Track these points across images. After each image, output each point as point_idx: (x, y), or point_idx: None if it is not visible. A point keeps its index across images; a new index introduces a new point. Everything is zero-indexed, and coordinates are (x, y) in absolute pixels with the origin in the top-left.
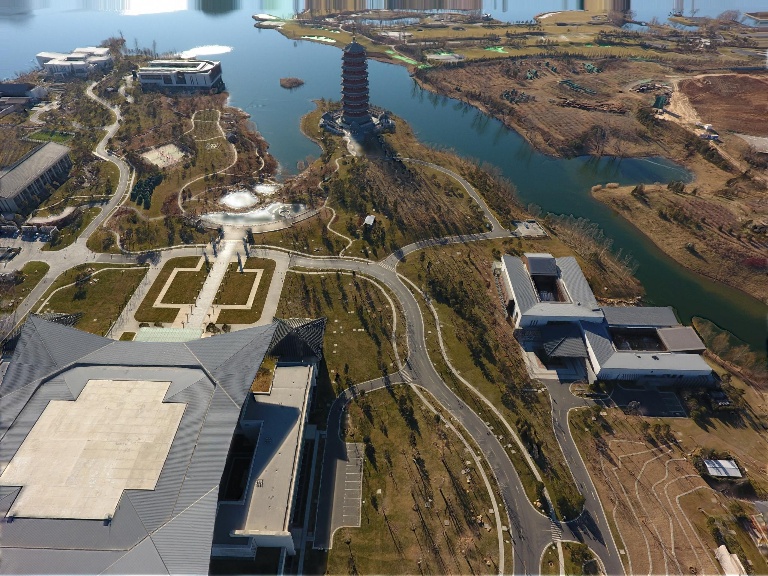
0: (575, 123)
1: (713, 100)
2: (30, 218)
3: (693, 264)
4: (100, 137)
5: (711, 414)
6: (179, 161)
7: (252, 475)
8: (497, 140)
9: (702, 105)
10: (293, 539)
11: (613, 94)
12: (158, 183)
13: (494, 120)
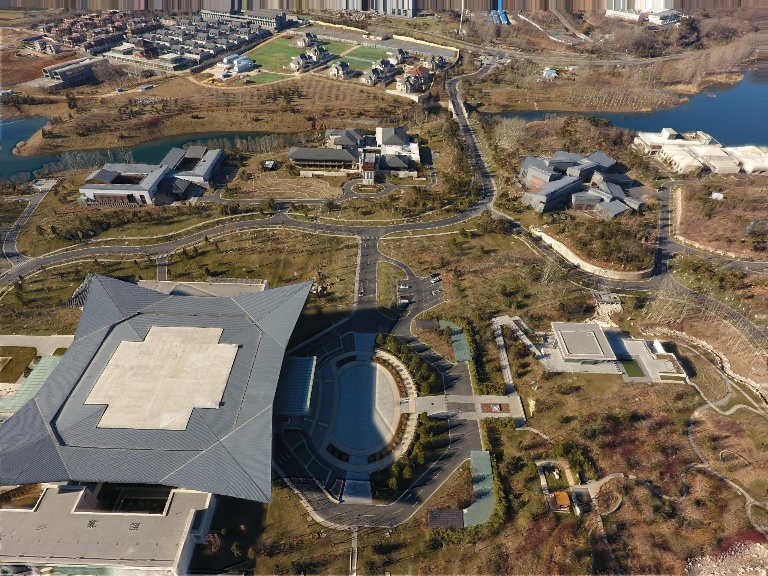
0: None
1: None
2: None
3: (135, 142)
4: None
5: (241, 162)
6: None
7: None
8: None
9: None
10: None
11: None
12: None
13: None
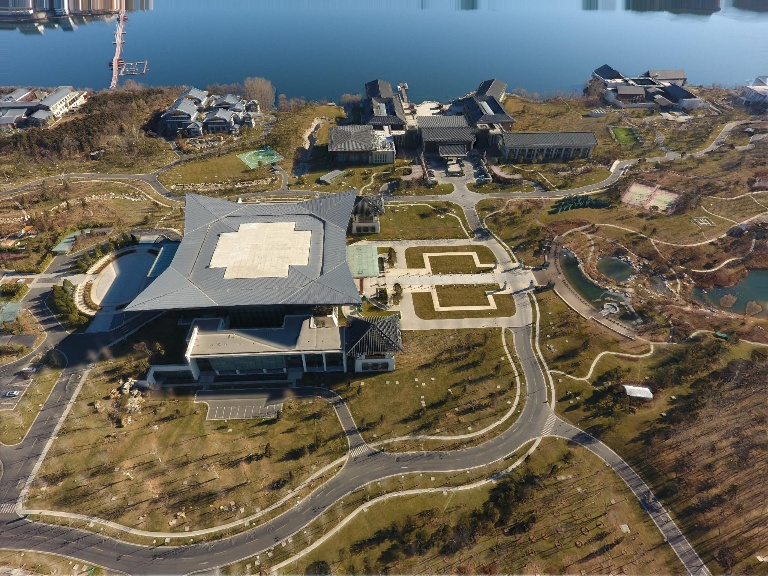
0: None
1: None
2: (500, 166)
3: None
4: (649, 155)
5: None
6: (647, 208)
7: (238, 331)
8: None
9: None
10: (206, 377)
11: None
12: (595, 207)
13: None
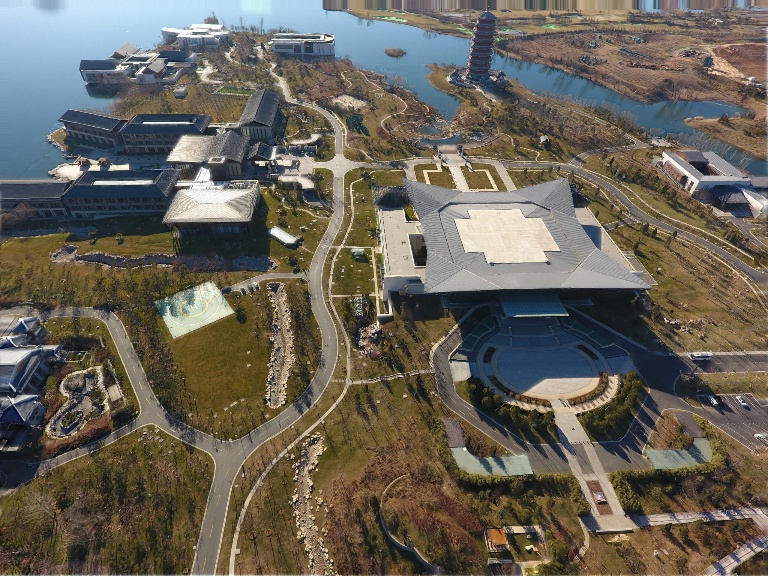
0: (649, 78)
1: (745, 62)
2: (286, 142)
3: None
4: (280, 91)
5: None
6: (363, 105)
7: None
8: (582, 95)
9: (739, 65)
10: None
11: (666, 58)
12: (361, 120)
13: (577, 79)
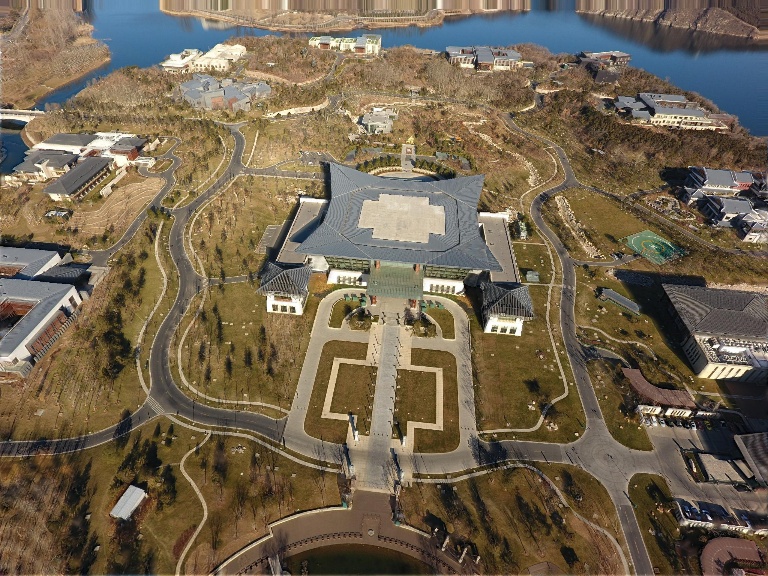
0: None
1: None
2: None
3: None
4: None
5: None
6: None
7: (319, 218)
8: None
9: None
10: None
11: None
12: None
13: None
